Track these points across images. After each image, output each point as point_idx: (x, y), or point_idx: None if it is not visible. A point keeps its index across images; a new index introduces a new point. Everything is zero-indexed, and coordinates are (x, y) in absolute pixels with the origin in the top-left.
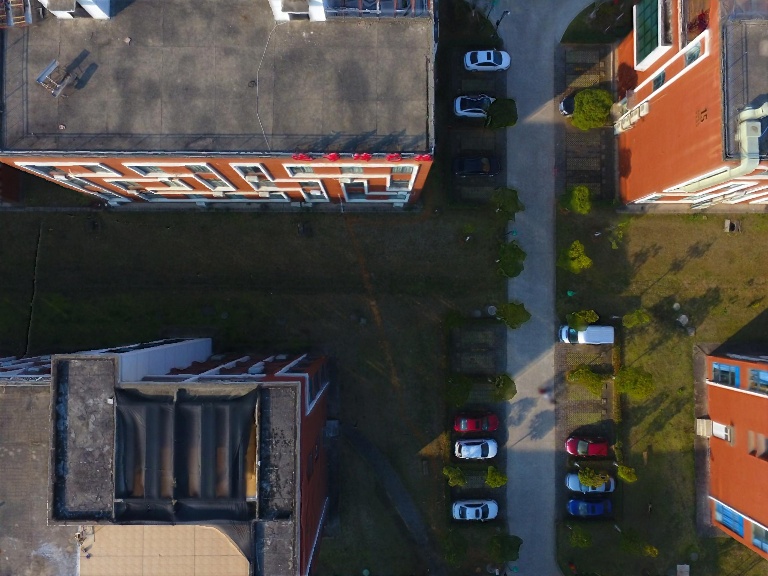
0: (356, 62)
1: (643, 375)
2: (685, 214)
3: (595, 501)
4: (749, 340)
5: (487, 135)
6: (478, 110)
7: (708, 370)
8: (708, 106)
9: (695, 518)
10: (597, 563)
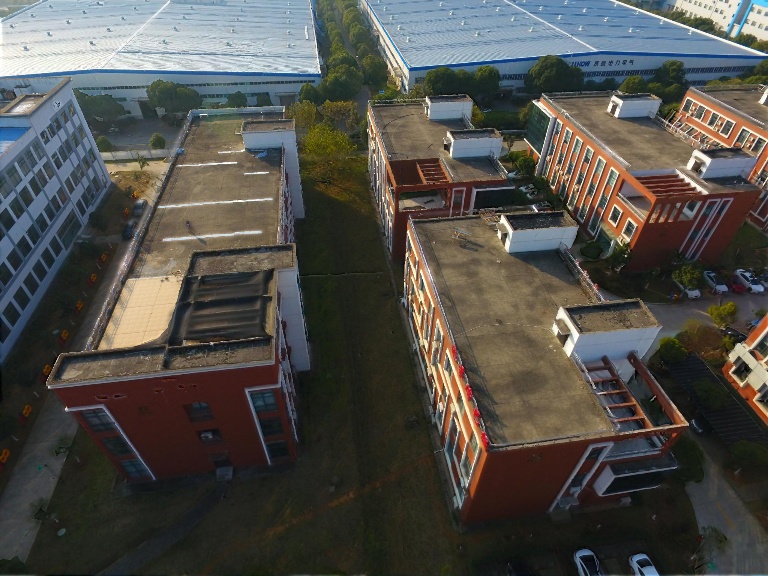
0: (547, 382)
1: None
2: None
3: None
4: None
5: None
6: None
7: None
8: None
9: None
10: None
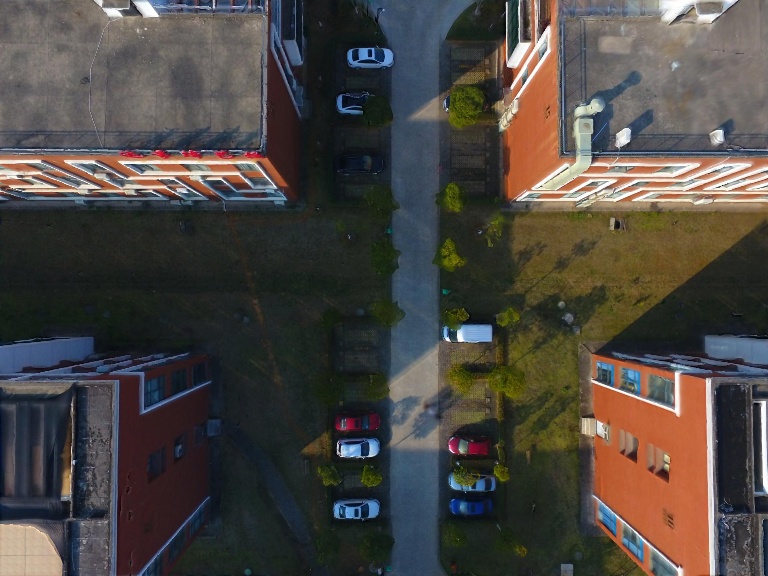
0: (190, 59)
1: (514, 374)
2: (570, 212)
3: (475, 500)
4: (635, 338)
5: (371, 133)
6: (359, 108)
7: (593, 369)
8: (550, 103)
9: (579, 517)
10: (480, 562)
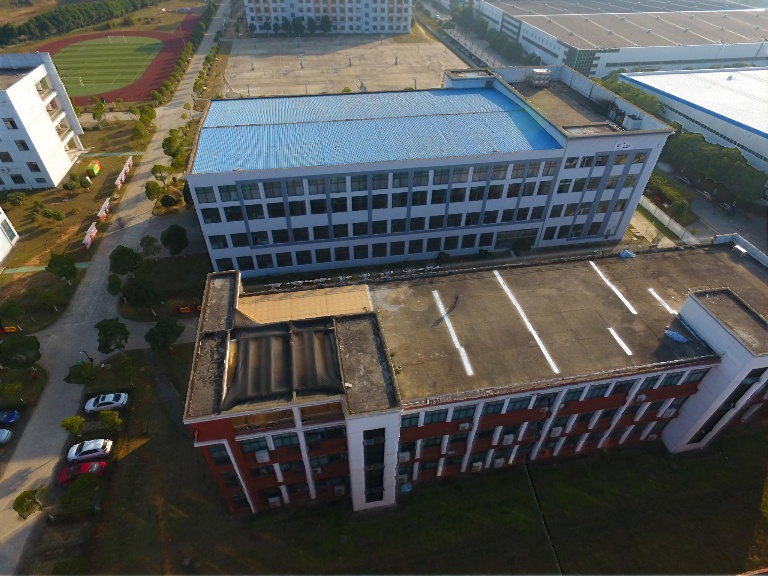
0: None
1: None
2: None
3: None
4: None
5: None
6: None
7: None
8: None
9: None
10: (12, 381)
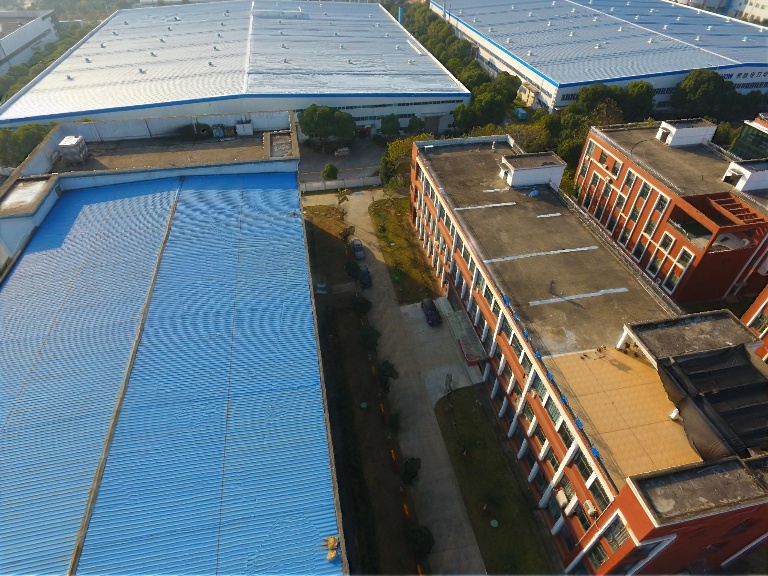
0: None
1: None
2: None
3: None
4: None
5: None
6: None
7: None
8: None
9: None
10: None
